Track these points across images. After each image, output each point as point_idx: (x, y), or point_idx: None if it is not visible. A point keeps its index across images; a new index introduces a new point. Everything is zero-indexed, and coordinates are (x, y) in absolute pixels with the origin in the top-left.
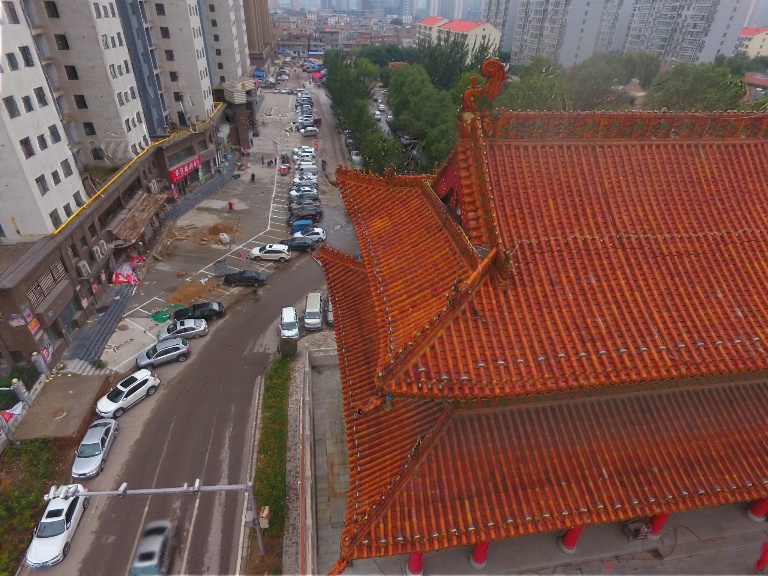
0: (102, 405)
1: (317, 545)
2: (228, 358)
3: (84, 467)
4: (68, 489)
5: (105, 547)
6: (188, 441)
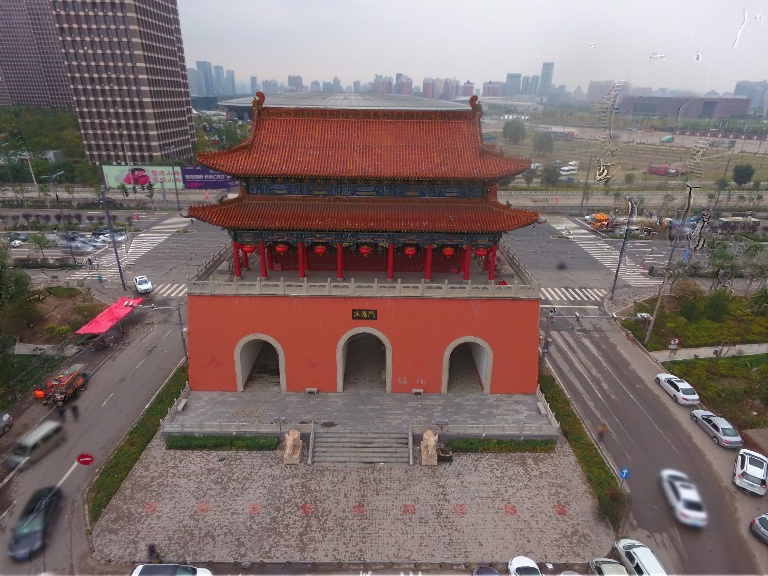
0: (759, 455)
1: None
2: (694, 526)
3: (702, 411)
4: (641, 315)
5: (637, 383)
6: (645, 432)
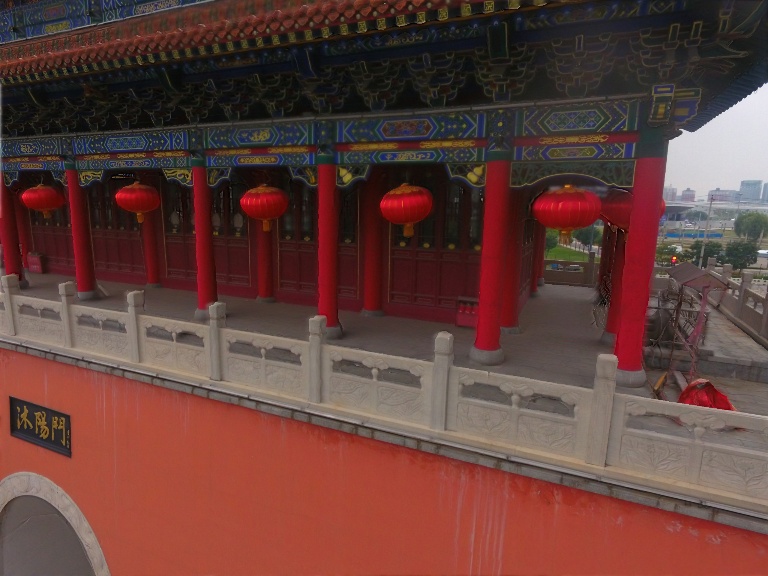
0: None
1: (731, 321)
2: None
3: None
4: None
5: None
6: None
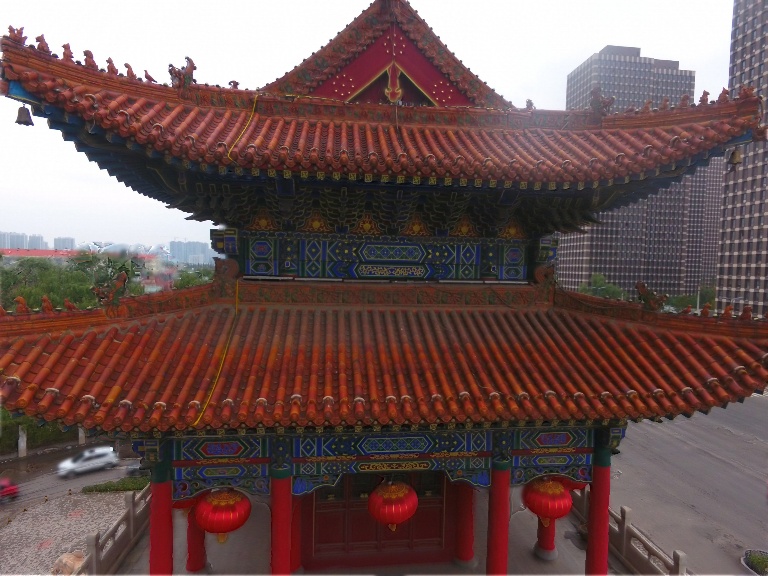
0: None
1: None
2: None
3: None
4: None
5: None
6: None
